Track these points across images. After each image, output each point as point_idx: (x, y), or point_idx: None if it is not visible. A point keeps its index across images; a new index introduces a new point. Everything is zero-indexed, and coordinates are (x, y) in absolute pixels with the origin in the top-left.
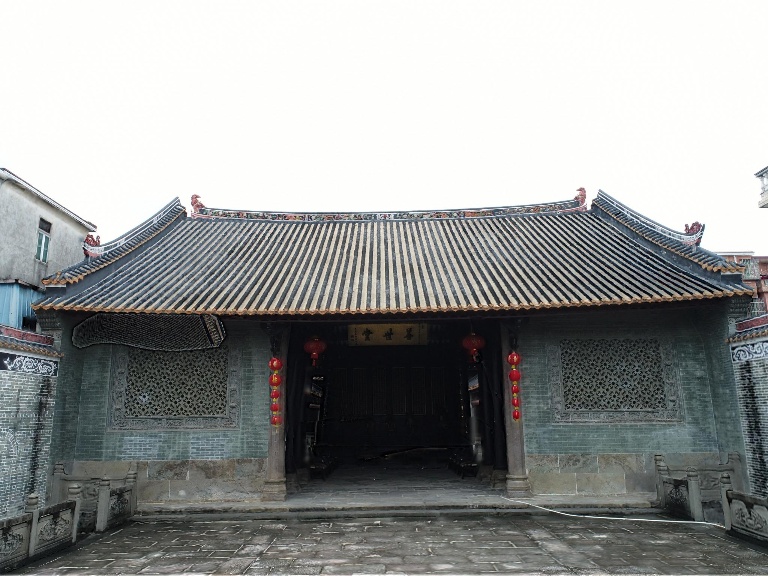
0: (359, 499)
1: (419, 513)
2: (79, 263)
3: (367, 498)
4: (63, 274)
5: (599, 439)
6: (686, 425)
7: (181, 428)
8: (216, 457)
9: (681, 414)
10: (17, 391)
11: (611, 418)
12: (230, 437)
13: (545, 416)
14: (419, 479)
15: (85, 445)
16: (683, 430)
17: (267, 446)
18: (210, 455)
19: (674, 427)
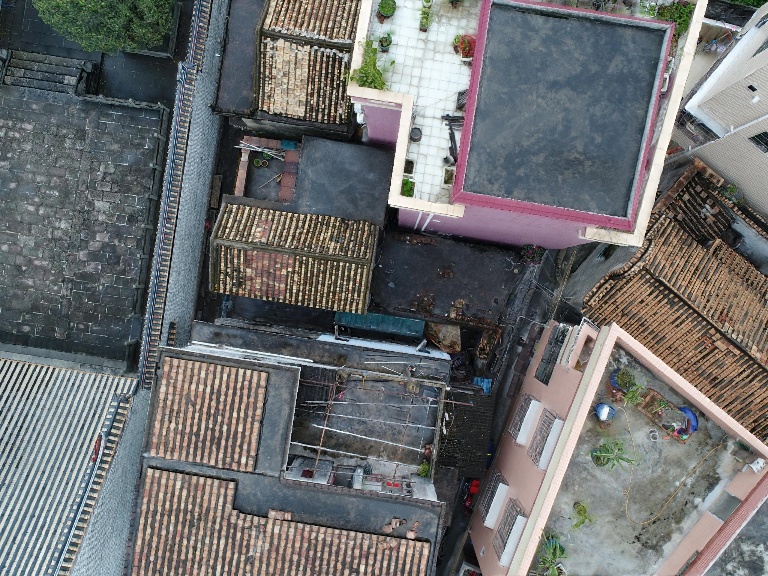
0: None
1: None
2: (109, 427)
3: None
4: (117, 399)
5: None
6: None
7: None
8: None
9: None
10: None
11: None
12: None
13: None
14: None
15: None
16: None
17: None
18: None
19: None
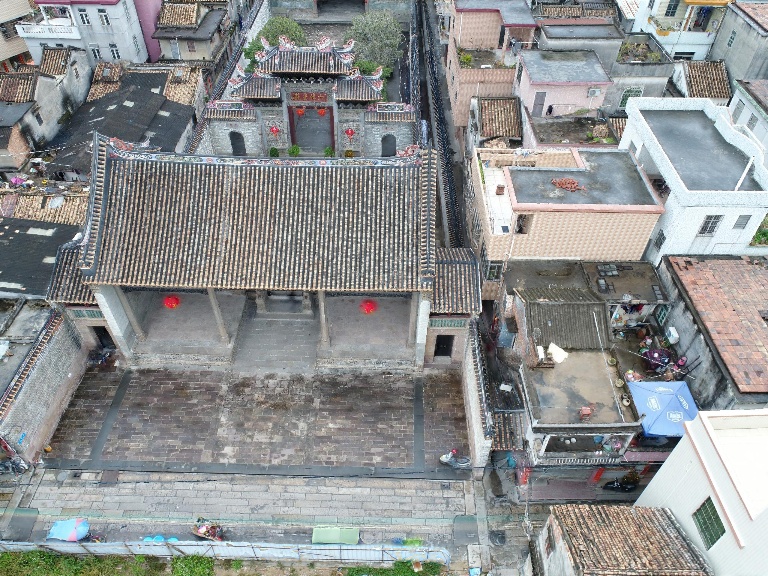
0: (334, 17)
1: (345, 23)
2: None
3: (336, 16)
4: None
5: (385, 6)
6: (405, 4)
7: (294, 0)
8: (303, 7)
9: (404, 1)
10: (266, 0)
11: (389, 1)
12: (305, 3)
13: (374, 1)
14: (351, 4)
15: (274, 4)
16: (404, 5)
17: (313, 5)
18: (301, 7)
19: (402, 4)
